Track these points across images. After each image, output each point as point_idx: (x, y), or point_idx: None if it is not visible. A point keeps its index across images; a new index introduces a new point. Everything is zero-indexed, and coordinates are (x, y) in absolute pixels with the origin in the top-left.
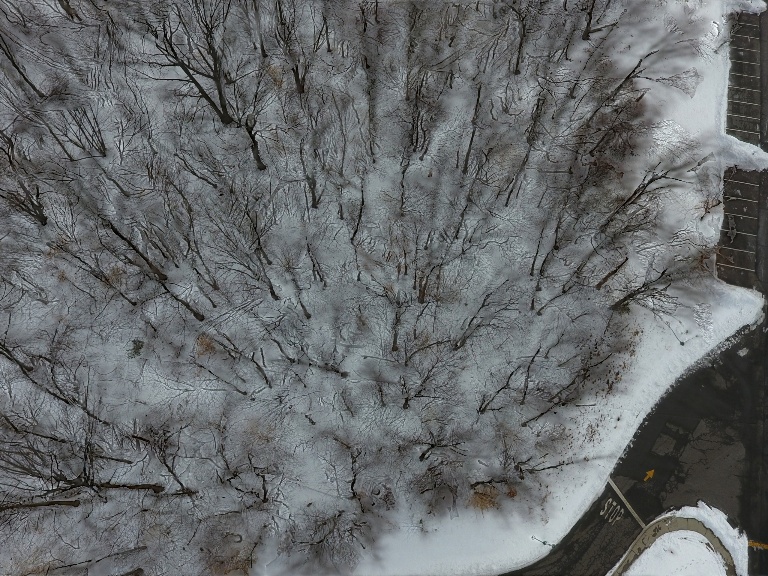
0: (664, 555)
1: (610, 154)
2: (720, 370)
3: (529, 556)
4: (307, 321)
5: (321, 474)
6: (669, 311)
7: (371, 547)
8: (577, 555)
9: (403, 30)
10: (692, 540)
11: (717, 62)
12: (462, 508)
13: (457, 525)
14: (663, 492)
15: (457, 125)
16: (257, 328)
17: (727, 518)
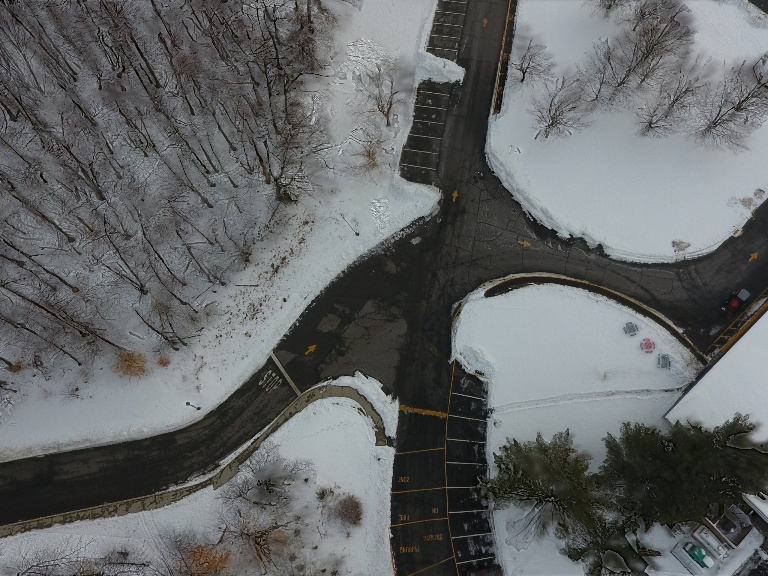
0: (313, 418)
1: (298, 68)
2: (392, 257)
3: (181, 420)
4: None
5: None
6: (309, 192)
7: (9, 405)
8: (230, 419)
9: None
10: (344, 405)
11: None
12: (117, 377)
13: (111, 392)
14: (322, 364)
15: (159, 47)
16: None
17: (382, 386)
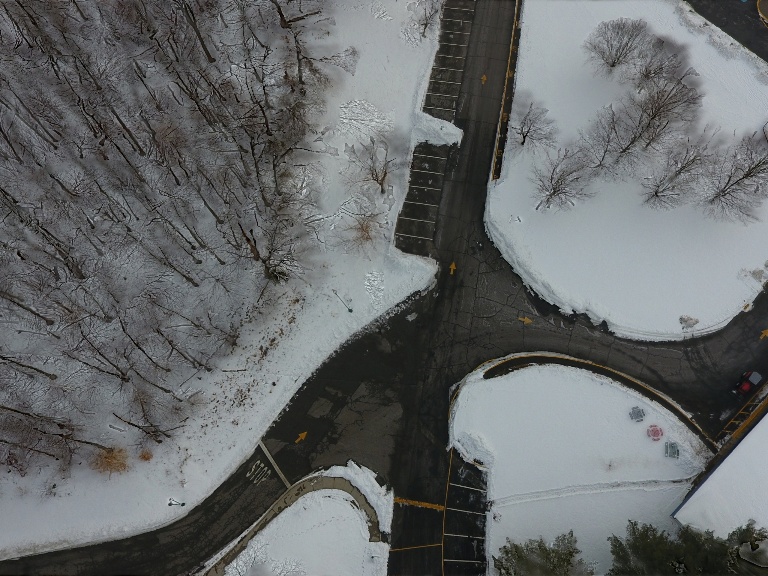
0: (303, 513)
1: (289, 133)
2: (387, 335)
3: (164, 517)
4: None
5: None
6: (299, 275)
7: None
8: (216, 516)
9: (105, 25)
10: (336, 498)
11: (424, 45)
12: (97, 472)
13: (91, 489)
14: (313, 453)
15: (143, 111)
16: None
17: (376, 476)
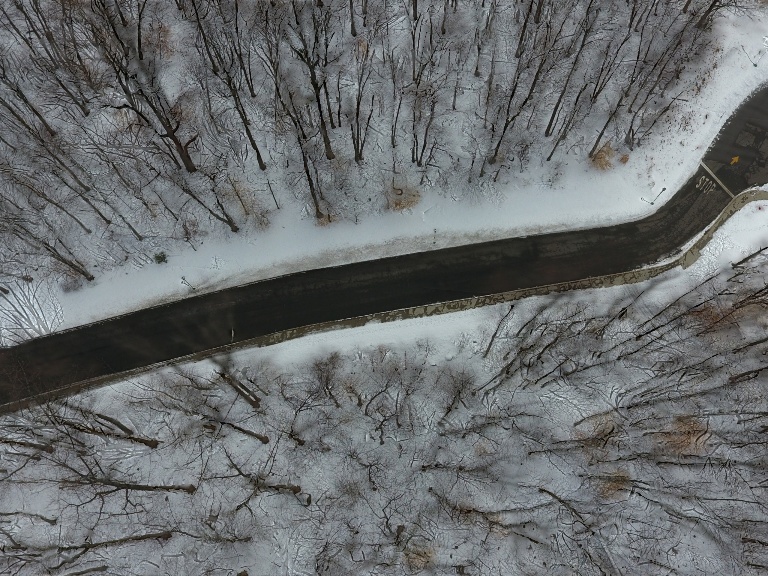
0: (752, 215)
1: None
2: None
3: (640, 211)
4: (443, 36)
5: (465, 144)
6: (750, 10)
7: None
8: (679, 214)
9: None
10: None
11: None
12: (583, 171)
13: (580, 184)
14: (747, 173)
15: None
16: (405, 32)
17: None
